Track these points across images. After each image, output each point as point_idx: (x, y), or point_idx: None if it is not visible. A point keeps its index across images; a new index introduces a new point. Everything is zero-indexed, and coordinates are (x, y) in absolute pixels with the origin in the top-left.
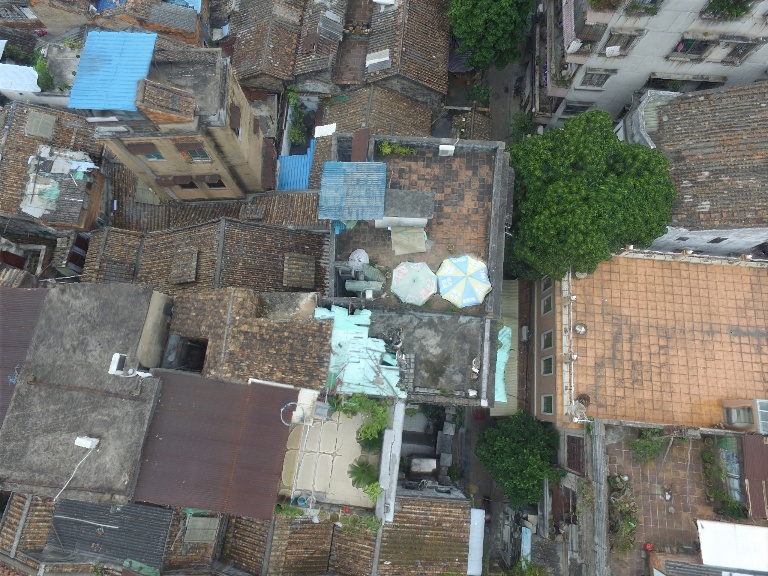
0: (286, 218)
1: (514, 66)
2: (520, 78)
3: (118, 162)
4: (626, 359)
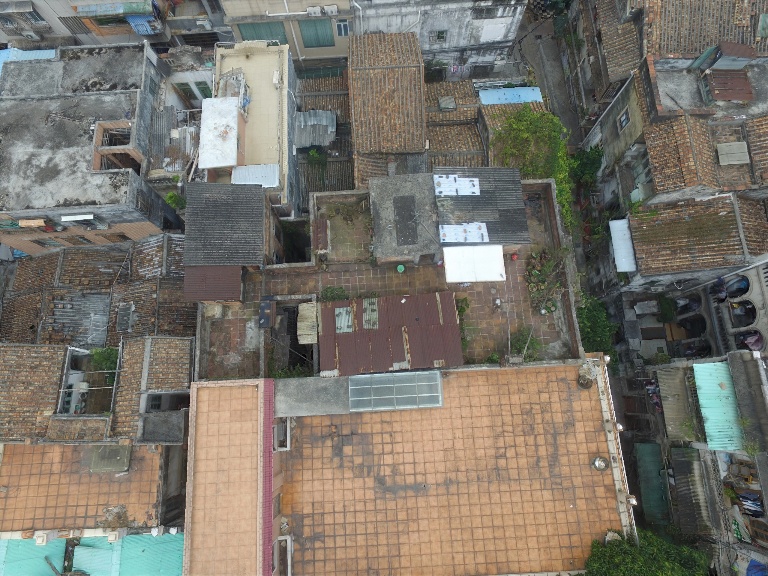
0: None
1: None
2: None
3: None
4: (541, 436)
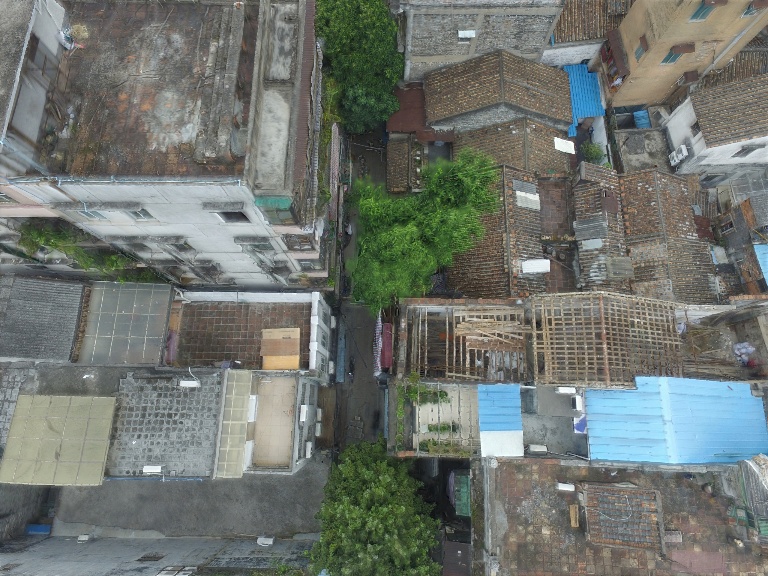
0: (587, 3)
1: (350, 321)
2: (346, 291)
3: (764, 48)
4: None
